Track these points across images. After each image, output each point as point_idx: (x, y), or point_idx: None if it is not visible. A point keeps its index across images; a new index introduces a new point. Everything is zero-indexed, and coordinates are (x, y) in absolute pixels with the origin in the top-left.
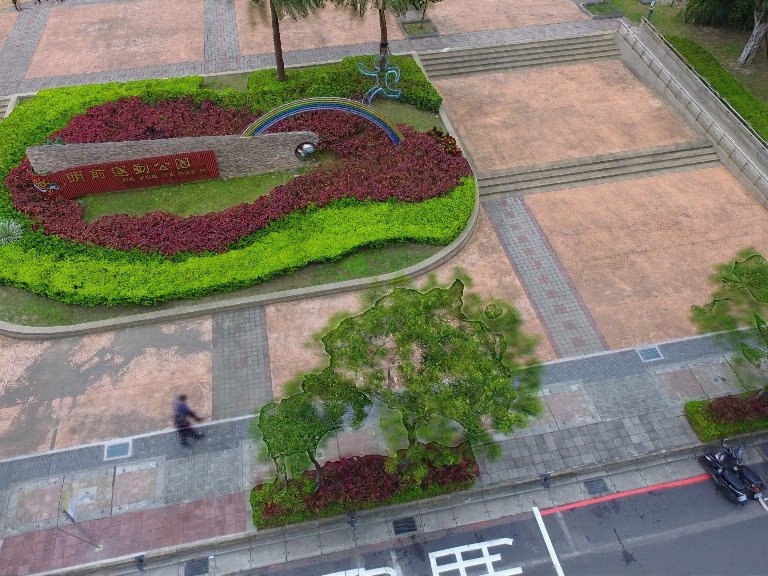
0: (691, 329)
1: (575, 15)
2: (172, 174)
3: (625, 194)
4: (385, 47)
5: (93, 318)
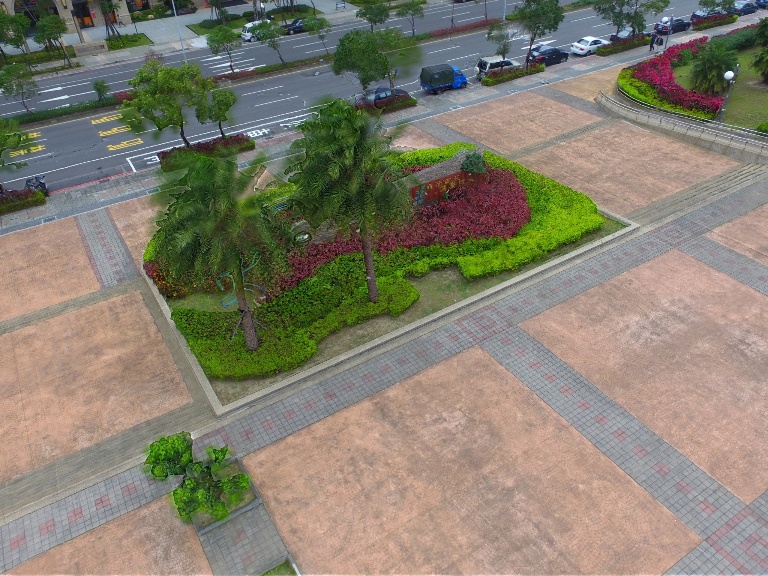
0: (14, 235)
1: None
2: None
3: None
4: None
5: None
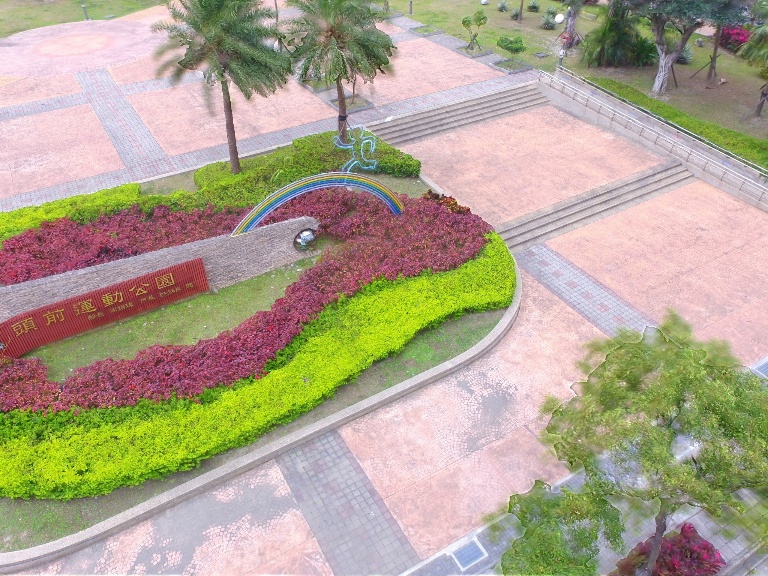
0: None
1: (490, 73)
2: (151, 297)
3: (636, 221)
4: (344, 120)
5: (114, 510)
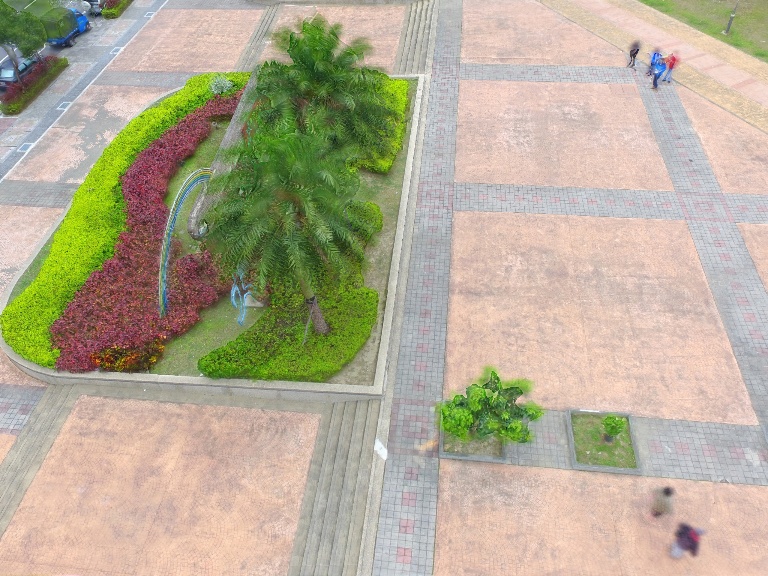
0: None
1: None
2: None
3: None
4: None
5: None
